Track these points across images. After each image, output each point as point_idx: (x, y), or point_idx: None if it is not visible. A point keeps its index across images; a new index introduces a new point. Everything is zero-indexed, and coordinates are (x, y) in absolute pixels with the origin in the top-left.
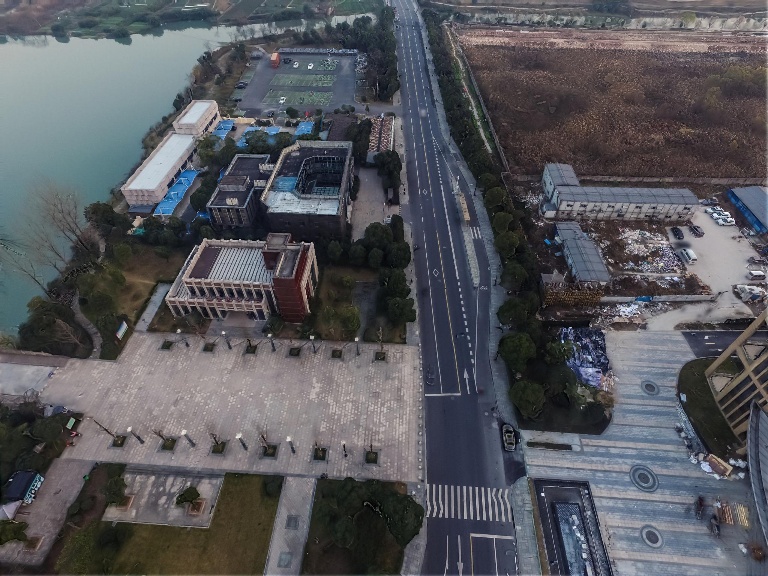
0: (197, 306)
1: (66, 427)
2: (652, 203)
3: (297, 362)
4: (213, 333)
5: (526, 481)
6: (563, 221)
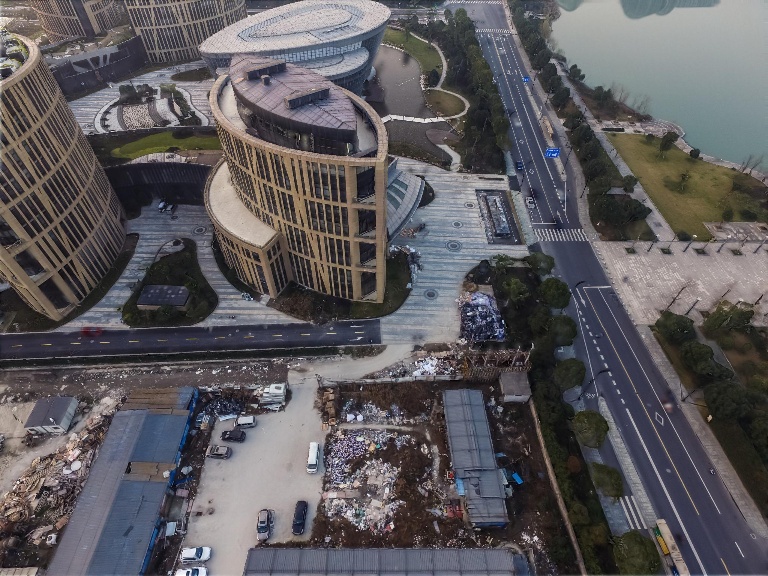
0: None
1: None
2: (339, 550)
3: None
4: None
5: (528, 243)
6: (488, 546)
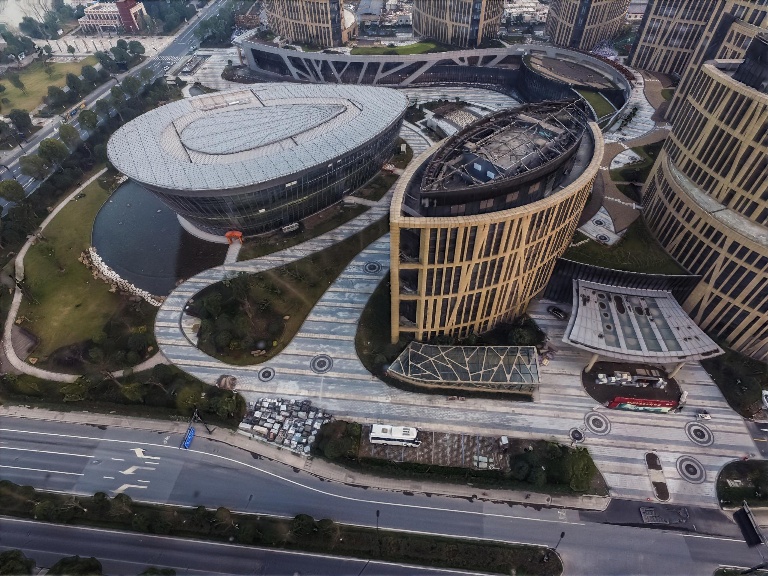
0: (91, 24)
1: (34, 47)
2: None
3: (127, 39)
4: (98, 35)
5: None
6: None
